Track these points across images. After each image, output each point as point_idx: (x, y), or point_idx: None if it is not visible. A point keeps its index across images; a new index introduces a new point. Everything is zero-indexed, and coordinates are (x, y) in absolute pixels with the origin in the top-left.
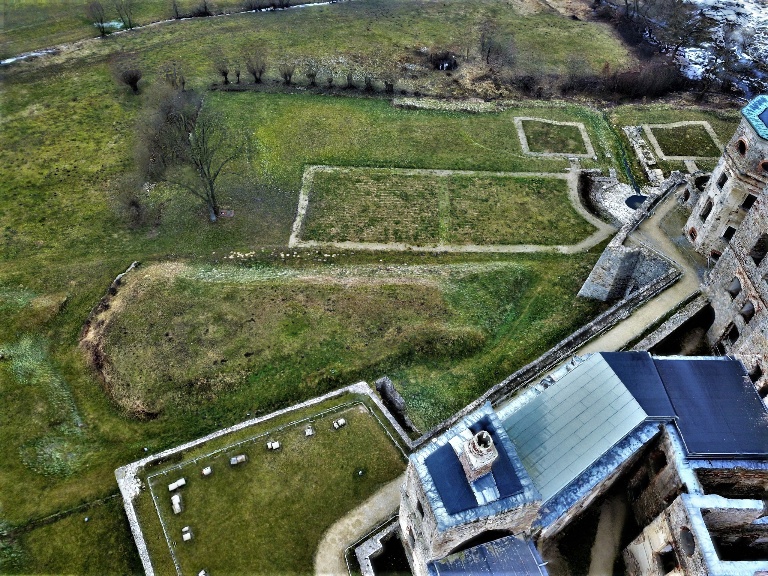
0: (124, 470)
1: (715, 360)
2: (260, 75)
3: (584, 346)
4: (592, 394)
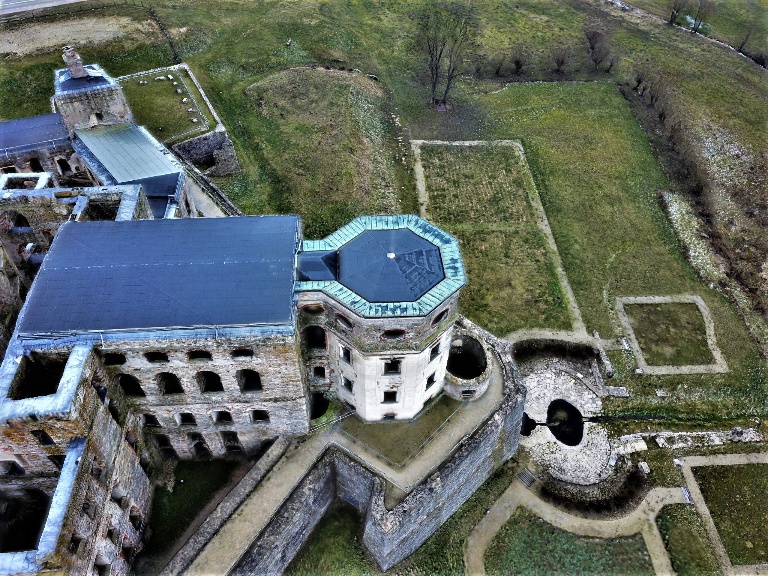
0: (184, 64)
1: None
2: (655, 101)
3: None
4: (145, 163)
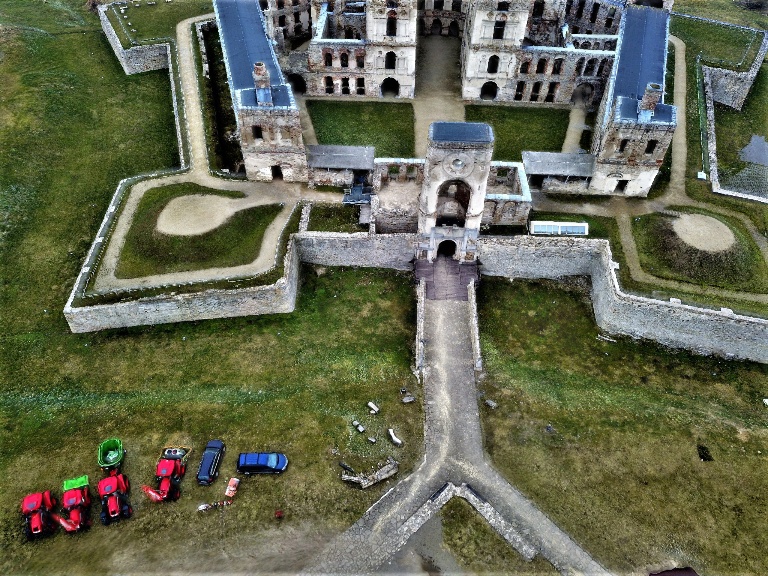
0: None
1: None
2: None
3: None
4: None
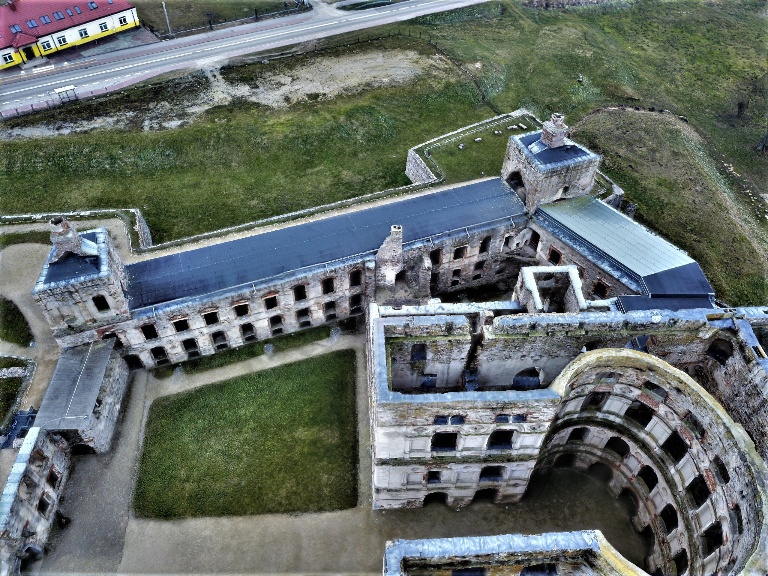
0: (525, 110)
1: None
2: None
3: None
4: (649, 250)
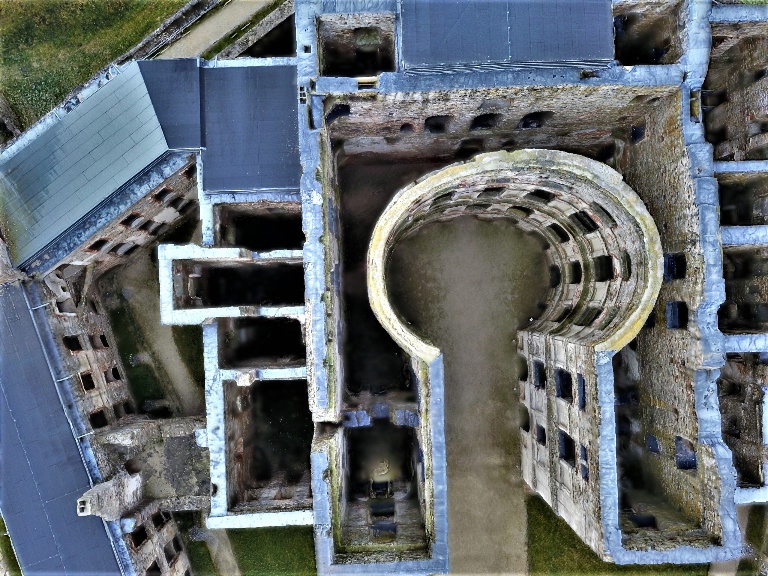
0: None
1: (280, 65)
2: None
3: (199, 24)
4: (113, 122)
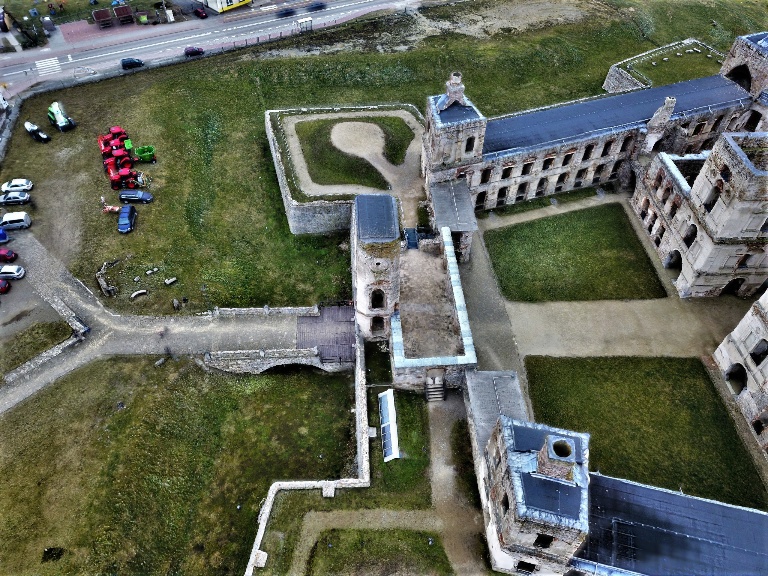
0: (693, 39)
1: None
2: None
3: None
4: None
